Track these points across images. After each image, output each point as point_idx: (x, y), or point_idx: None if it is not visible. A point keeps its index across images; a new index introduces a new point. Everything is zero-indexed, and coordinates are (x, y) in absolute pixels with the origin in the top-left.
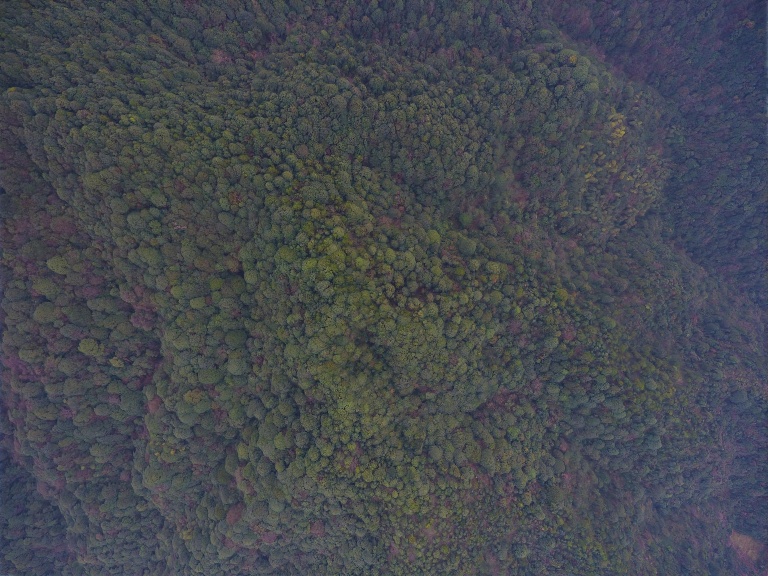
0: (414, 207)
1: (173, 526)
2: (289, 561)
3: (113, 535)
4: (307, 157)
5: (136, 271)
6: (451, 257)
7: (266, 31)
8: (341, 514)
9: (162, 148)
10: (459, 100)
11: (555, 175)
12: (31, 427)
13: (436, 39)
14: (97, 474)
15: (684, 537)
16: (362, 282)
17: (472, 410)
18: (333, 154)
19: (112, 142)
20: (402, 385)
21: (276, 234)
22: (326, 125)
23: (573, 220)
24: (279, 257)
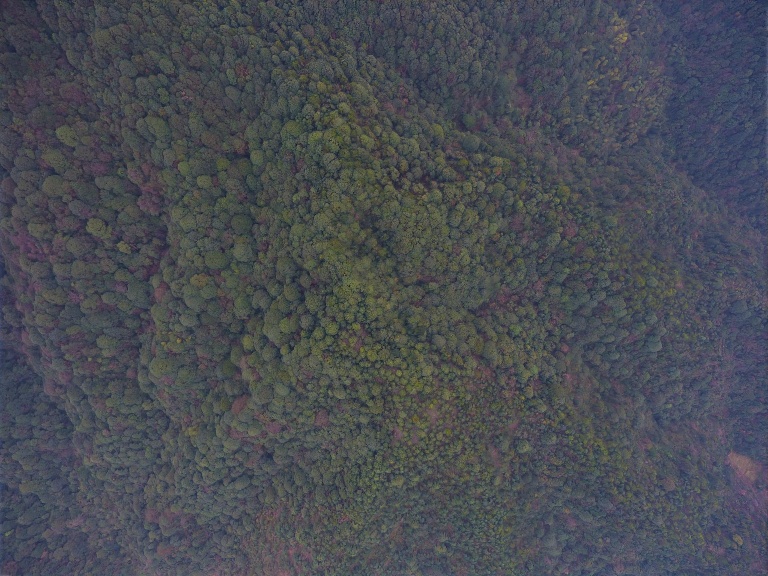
0: (418, 102)
1: (178, 427)
2: (293, 461)
3: (119, 432)
4: (313, 37)
5: (144, 145)
6: (455, 152)
7: None
8: (345, 398)
9: (170, 10)
10: None
11: (558, 79)
12: (39, 311)
13: None
14: (104, 368)
15: (683, 446)
16: (367, 160)
17: (475, 308)
18: (338, 39)
19: None
20: (406, 272)
21: (282, 107)
22: (332, 6)
23: (575, 128)
24: (285, 131)
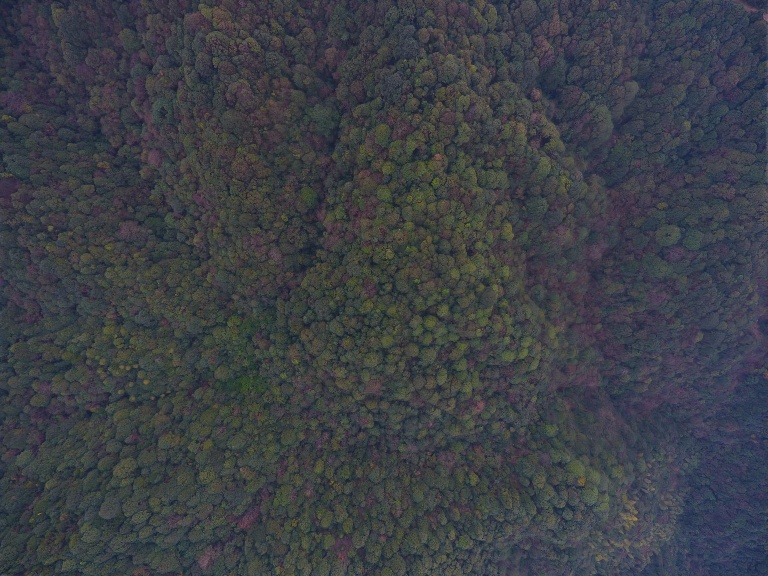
0: None
1: None
2: None
3: None
4: None
5: None
6: None
7: None
8: None
9: None
10: (461, 546)
11: (564, 572)
12: None
13: (436, 444)
14: None
15: None
16: None
17: None
18: None
19: None
20: None
21: None
22: None
23: None
24: None
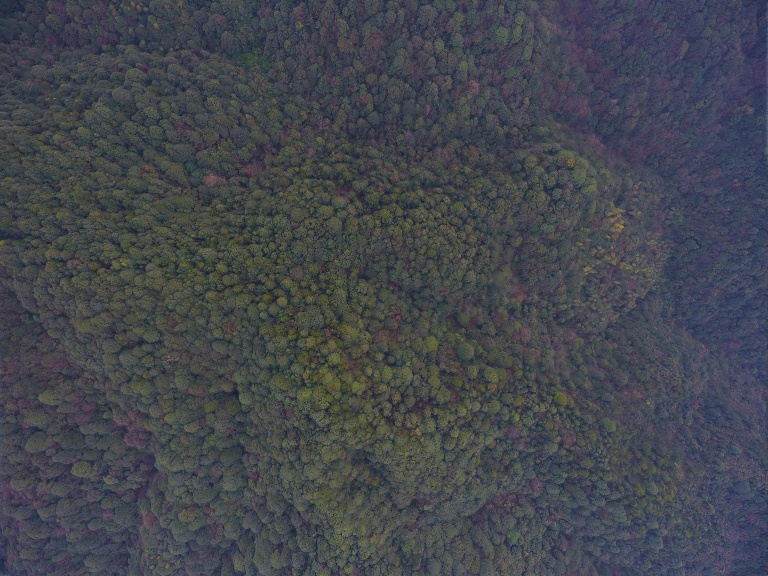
0: (411, 314)
1: None
2: None
3: None
4: (302, 279)
5: (129, 400)
6: (449, 363)
7: (260, 143)
8: None
9: (154, 288)
10: (456, 209)
11: (554, 272)
12: (24, 546)
13: (432, 139)
14: None
15: None
16: (358, 407)
17: (471, 514)
18: (328, 271)
19: (103, 290)
20: (400, 500)
21: (271, 363)
22: (321, 245)
23: (572, 312)
24: (274, 385)
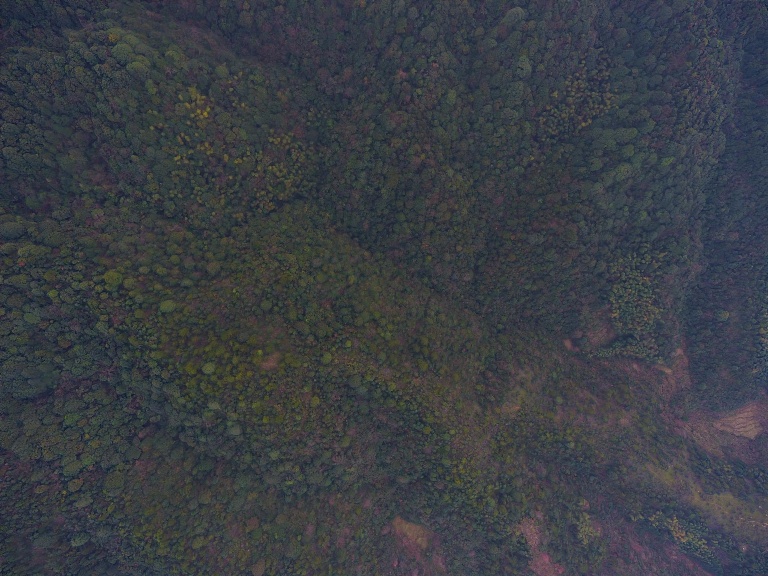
0: None
1: None
2: None
3: None
4: None
5: None
6: None
7: None
8: None
9: None
10: None
11: (129, 157)
12: None
13: None
14: None
15: (301, 524)
16: None
17: (32, 397)
18: None
19: None
20: None
21: None
22: None
23: (170, 204)
24: None
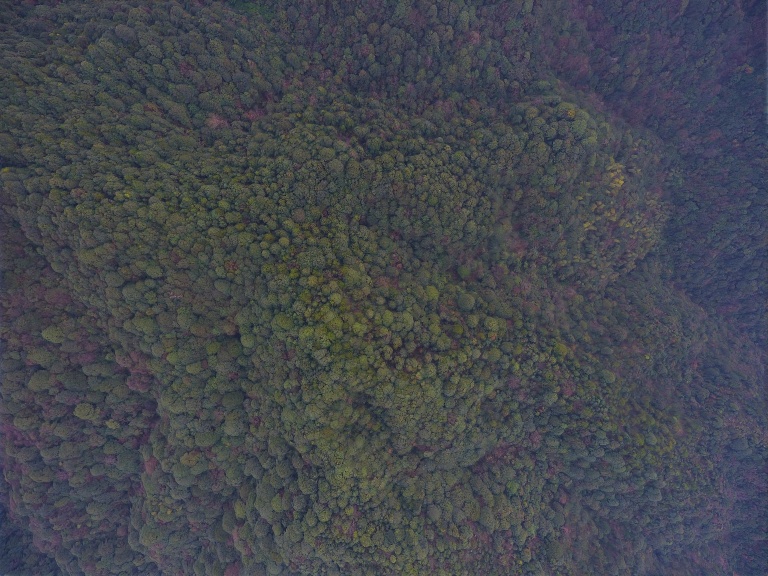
0: (412, 263)
1: None
2: None
3: None
4: (304, 221)
5: (132, 339)
6: (449, 313)
7: (262, 90)
8: None
9: (157, 222)
10: (457, 157)
11: (554, 226)
12: (26, 489)
13: (434, 91)
14: (93, 531)
15: None
16: (359, 347)
17: (471, 464)
18: (330, 215)
19: (107, 220)
20: (400, 445)
21: (273, 302)
22: (323, 188)
23: (572, 269)
24: (276, 324)
